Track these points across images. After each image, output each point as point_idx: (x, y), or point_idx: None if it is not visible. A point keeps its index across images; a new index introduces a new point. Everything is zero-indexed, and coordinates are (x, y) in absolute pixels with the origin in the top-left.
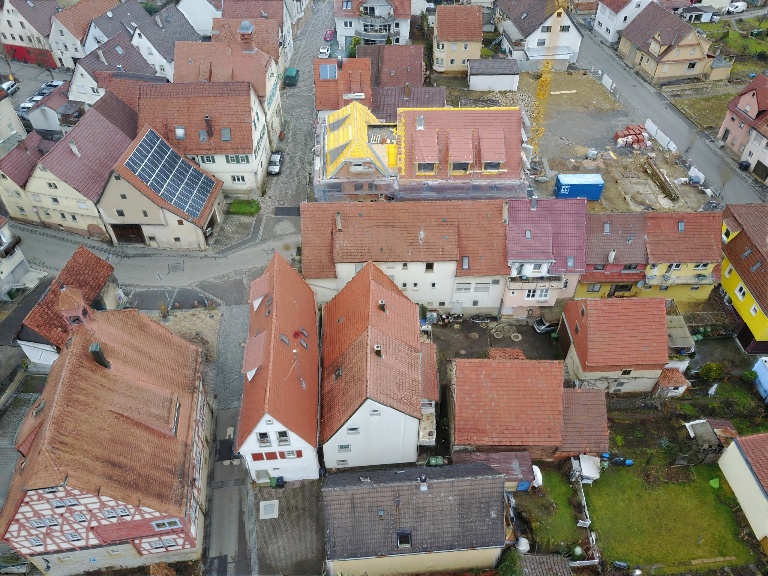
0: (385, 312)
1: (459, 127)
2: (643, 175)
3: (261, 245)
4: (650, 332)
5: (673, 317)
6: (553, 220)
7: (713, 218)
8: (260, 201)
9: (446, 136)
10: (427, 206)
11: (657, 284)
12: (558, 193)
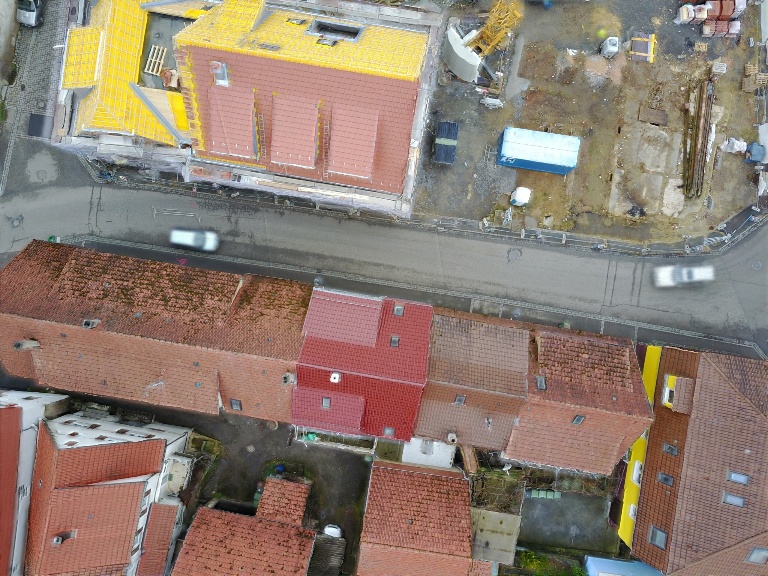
0: (71, 536)
1: (295, 93)
2: (676, 118)
3: (4, 205)
4: (443, 572)
5: (508, 516)
6: (368, 394)
7: (635, 423)
8: (6, 96)
9: (271, 104)
10: (166, 346)
11: (515, 459)
12: (497, 158)
